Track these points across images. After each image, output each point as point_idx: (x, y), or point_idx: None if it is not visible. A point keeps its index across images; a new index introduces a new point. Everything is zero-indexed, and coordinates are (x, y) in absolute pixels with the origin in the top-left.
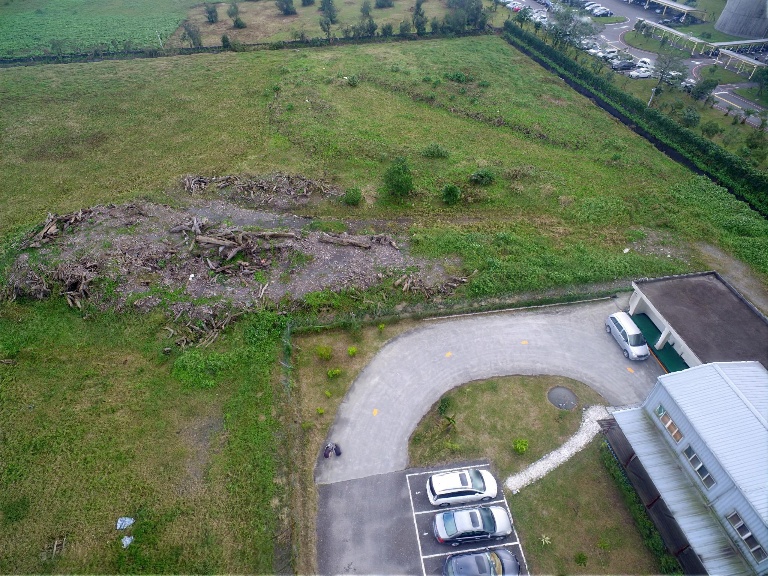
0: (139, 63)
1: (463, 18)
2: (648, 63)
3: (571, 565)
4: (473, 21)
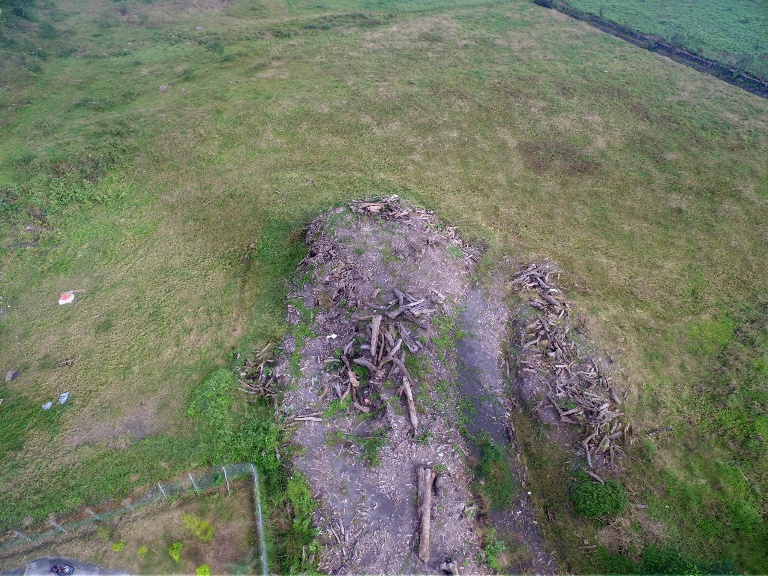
0: None
1: None
2: None
3: None
4: None
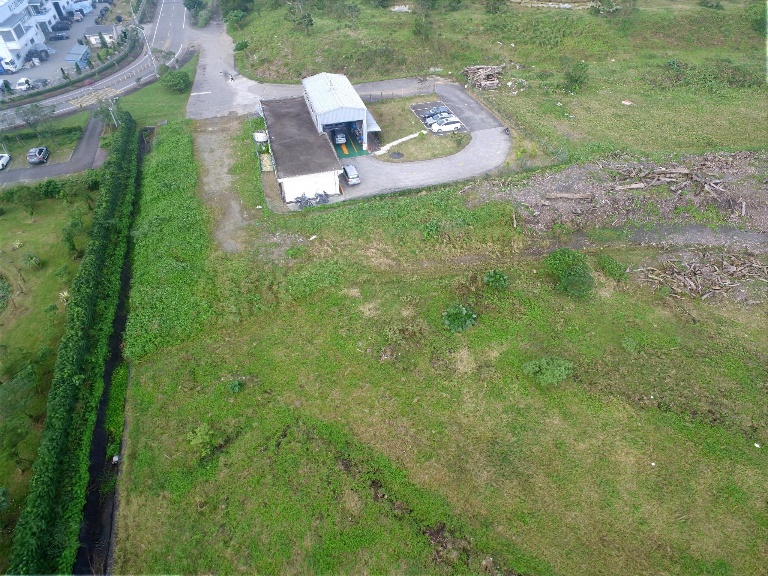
0: None
1: None
2: None
3: None
4: None
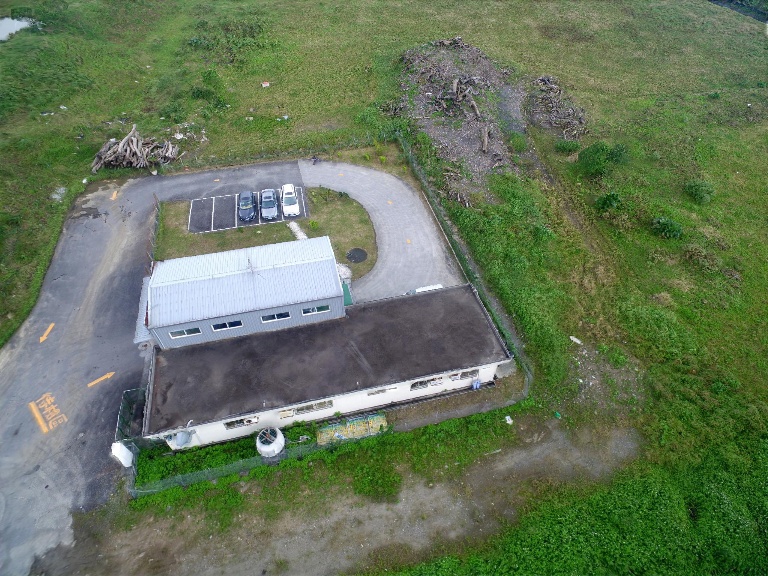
0: (740, 20)
1: None
2: None
3: (246, 242)
4: None
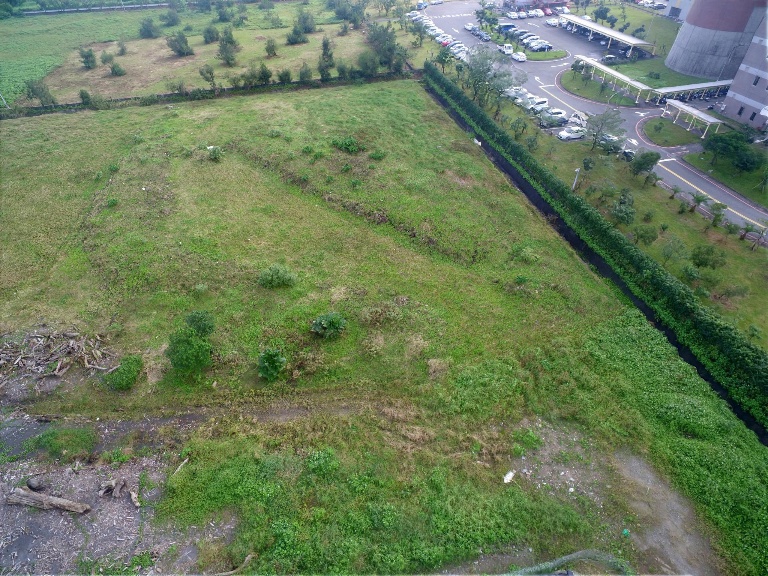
0: None
1: (372, 61)
2: (582, 118)
3: None
4: (387, 63)
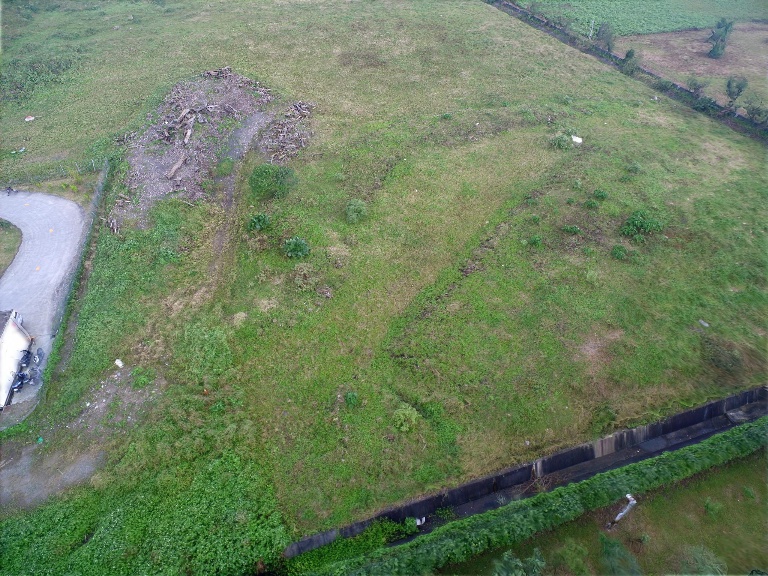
0: (543, 42)
1: None
2: None
3: None
4: None
